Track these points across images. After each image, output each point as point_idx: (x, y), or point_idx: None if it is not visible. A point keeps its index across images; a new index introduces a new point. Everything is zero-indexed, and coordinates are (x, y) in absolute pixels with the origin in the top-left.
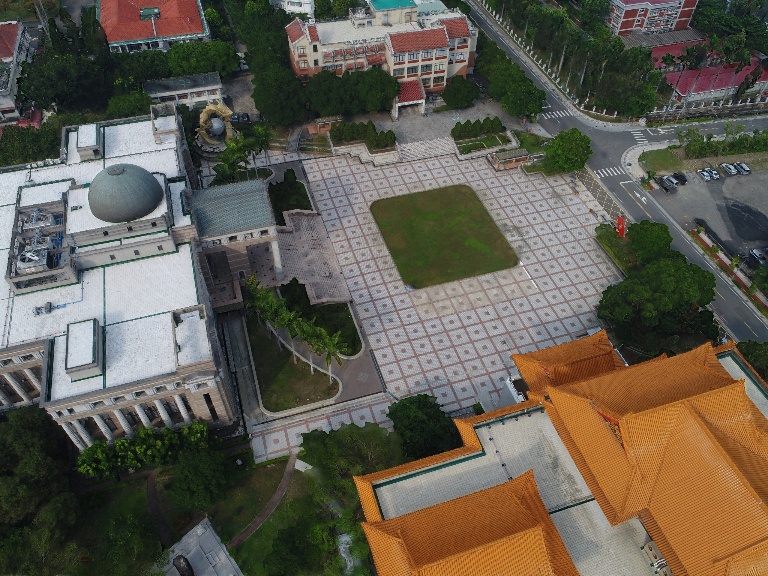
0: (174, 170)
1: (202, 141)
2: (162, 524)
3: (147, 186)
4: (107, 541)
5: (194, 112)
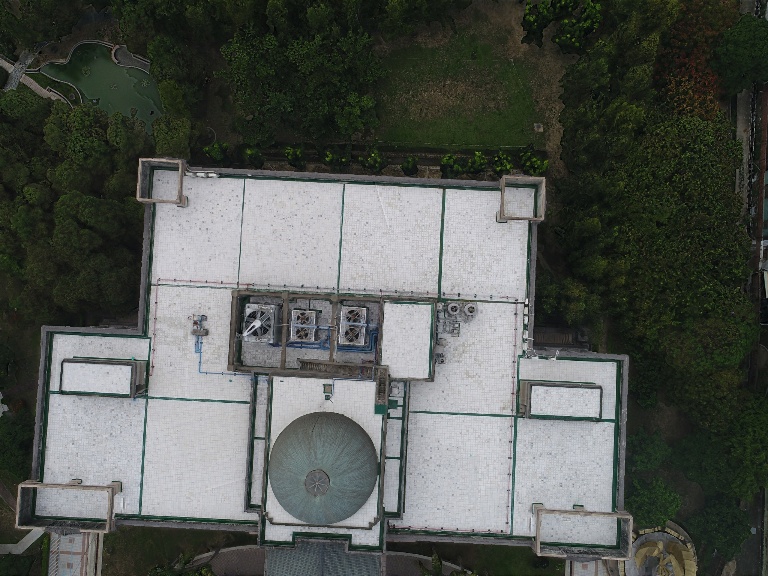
0: (447, 523)
1: (653, 538)
2: (27, 388)
3: (296, 515)
4: None
5: (726, 547)
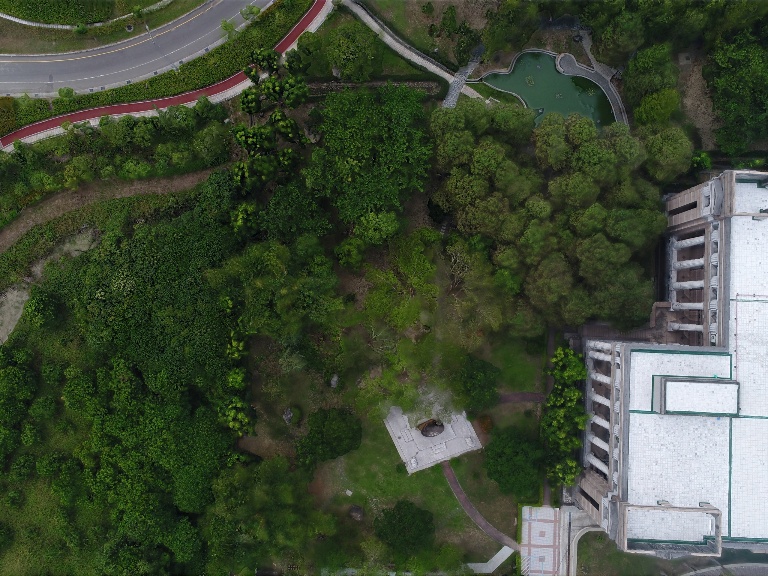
0: None
1: None
2: None
3: None
4: (479, 366)
5: None
